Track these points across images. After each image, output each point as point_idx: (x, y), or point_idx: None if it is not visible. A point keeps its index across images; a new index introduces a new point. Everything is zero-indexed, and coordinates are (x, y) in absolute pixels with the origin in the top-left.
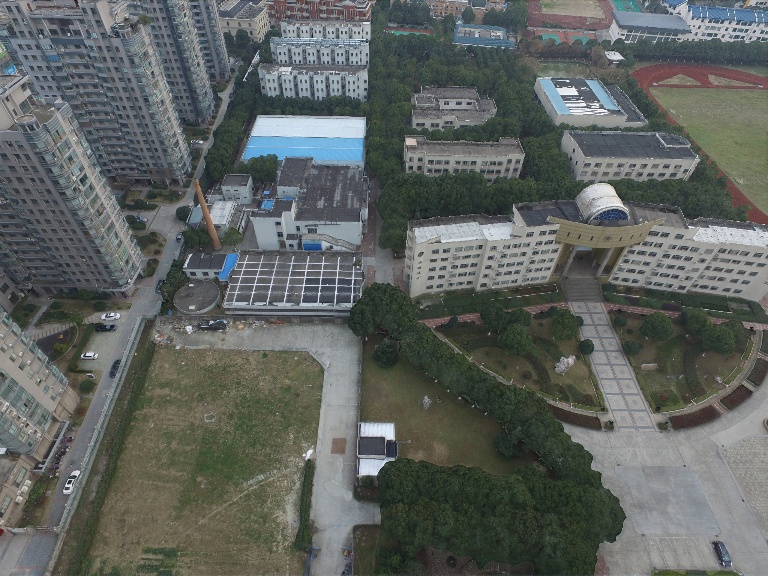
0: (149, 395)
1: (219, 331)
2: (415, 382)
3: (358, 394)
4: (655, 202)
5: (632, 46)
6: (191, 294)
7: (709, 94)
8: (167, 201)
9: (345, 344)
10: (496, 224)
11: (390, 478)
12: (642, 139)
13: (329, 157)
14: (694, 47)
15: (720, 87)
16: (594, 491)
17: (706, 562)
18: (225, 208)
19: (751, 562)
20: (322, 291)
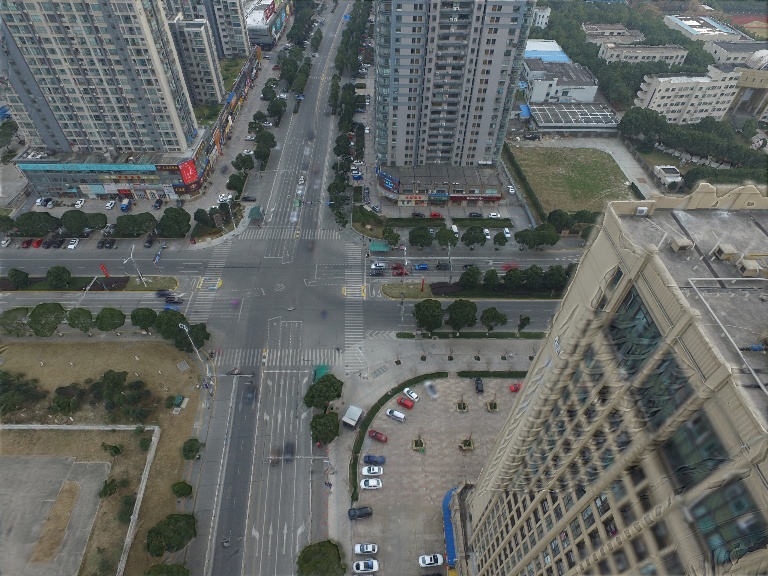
0: (519, 163)
1: (536, 140)
2: (667, 159)
3: (640, 161)
4: None
5: (717, 1)
6: None
7: None
8: None
9: (615, 145)
10: (698, 77)
11: (699, 170)
12: (760, 45)
13: (547, 60)
14: (765, 1)
15: None
16: None
17: None
18: None
19: None
20: (593, 119)
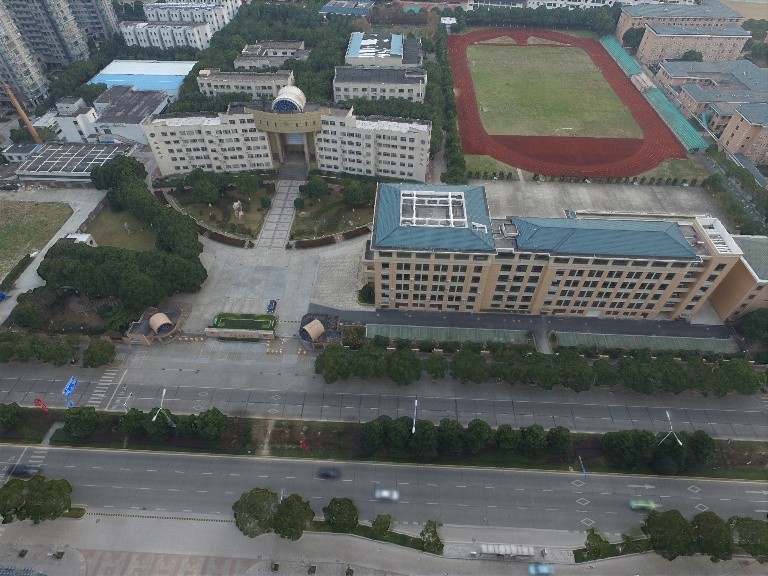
0: None
1: (12, 191)
2: (132, 220)
3: (85, 224)
4: (373, 113)
5: (468, 13)
6: (4, 170)
7: (517, 50)
8: (19, 117)
9: (97, 199)
10: (218, 118)
11: None
12: (394, 72)
13: (151, 87)
14: (521, 13)
15: (531, 45)
16: (177, 256)
17: (259, 311)
18: (51, 117)
19: (289, 312)
20: None
